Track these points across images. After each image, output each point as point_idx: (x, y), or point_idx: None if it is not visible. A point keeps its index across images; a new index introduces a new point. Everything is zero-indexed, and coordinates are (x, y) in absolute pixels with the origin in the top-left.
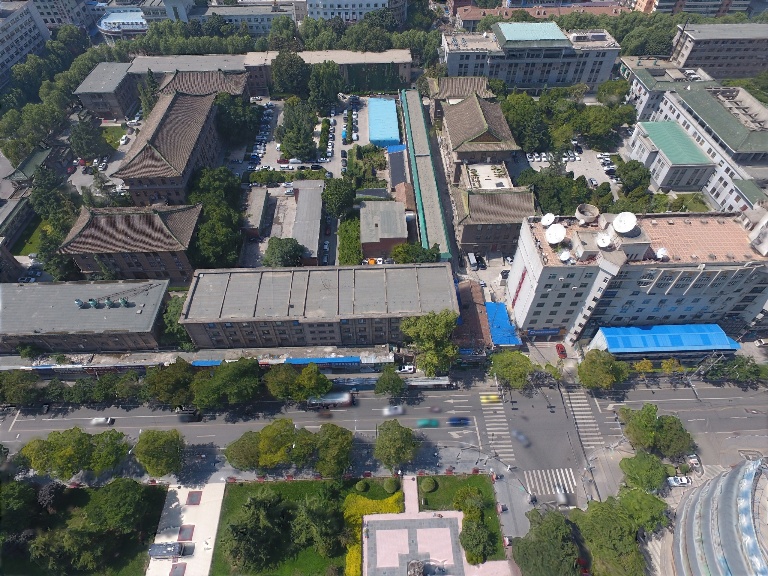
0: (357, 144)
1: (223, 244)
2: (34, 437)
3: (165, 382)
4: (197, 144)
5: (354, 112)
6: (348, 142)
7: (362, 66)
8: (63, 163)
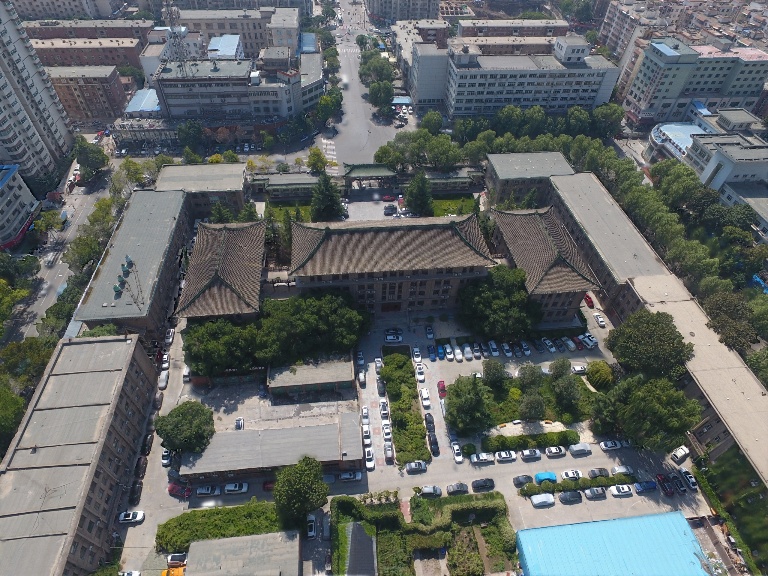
0: (502, 506)
1: (200, 352)
2: (54, 285)
3: (3, 350)
4: (385, 276)
5: (626, 487)
6: (522, 488)
7: (757, 477)
8: (395, 190)
